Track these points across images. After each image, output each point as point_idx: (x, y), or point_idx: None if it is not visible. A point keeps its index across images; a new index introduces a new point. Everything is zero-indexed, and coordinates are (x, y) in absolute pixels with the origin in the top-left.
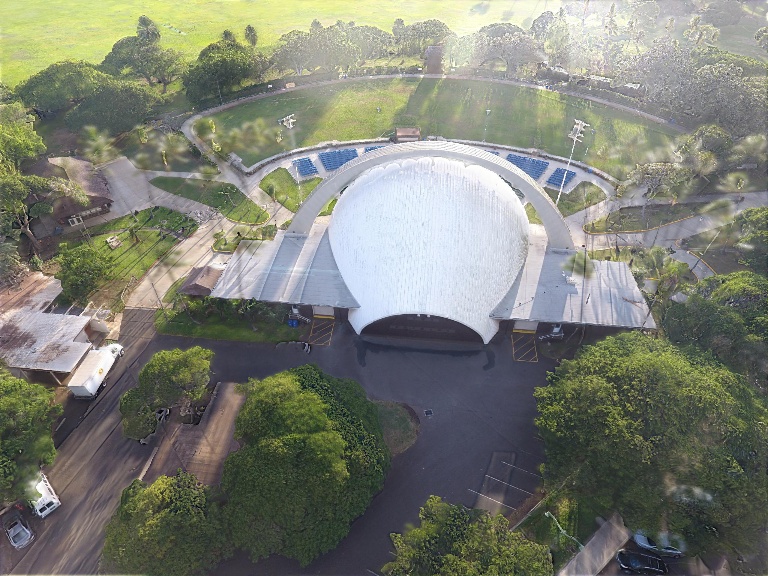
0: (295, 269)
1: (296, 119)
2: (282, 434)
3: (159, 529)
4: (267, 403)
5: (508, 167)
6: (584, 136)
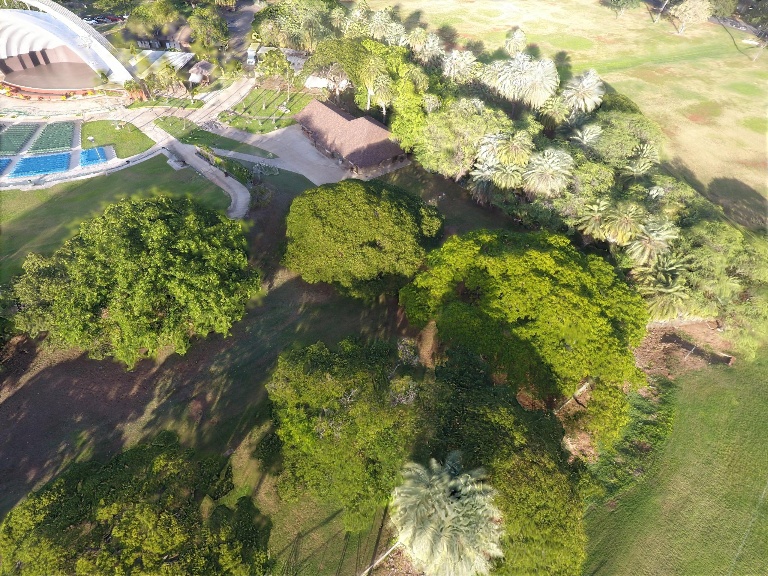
0: (141, 59)
1: (57, 226)
2: (160, 4)
3: (204, 8)
4: (163, 6)
5: None
6: None
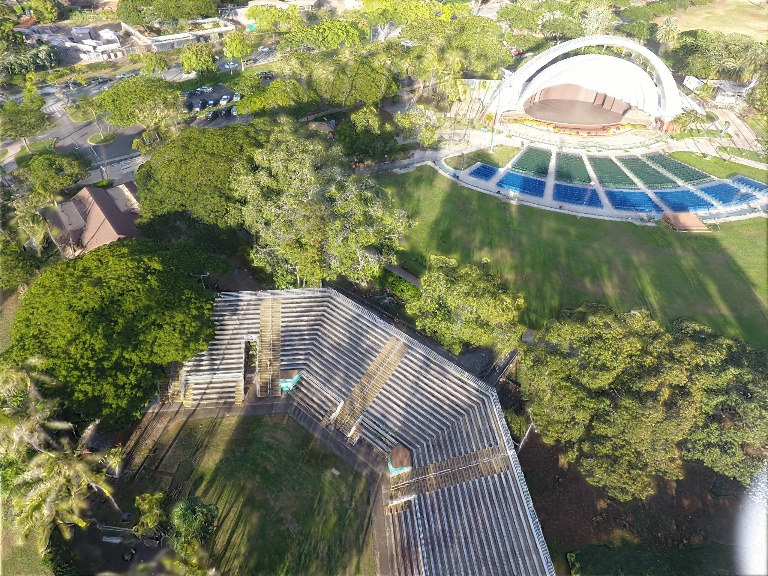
0: None
1: None
2: None
3: None
4: None
5: (557, 46)
6: (452, 213)
